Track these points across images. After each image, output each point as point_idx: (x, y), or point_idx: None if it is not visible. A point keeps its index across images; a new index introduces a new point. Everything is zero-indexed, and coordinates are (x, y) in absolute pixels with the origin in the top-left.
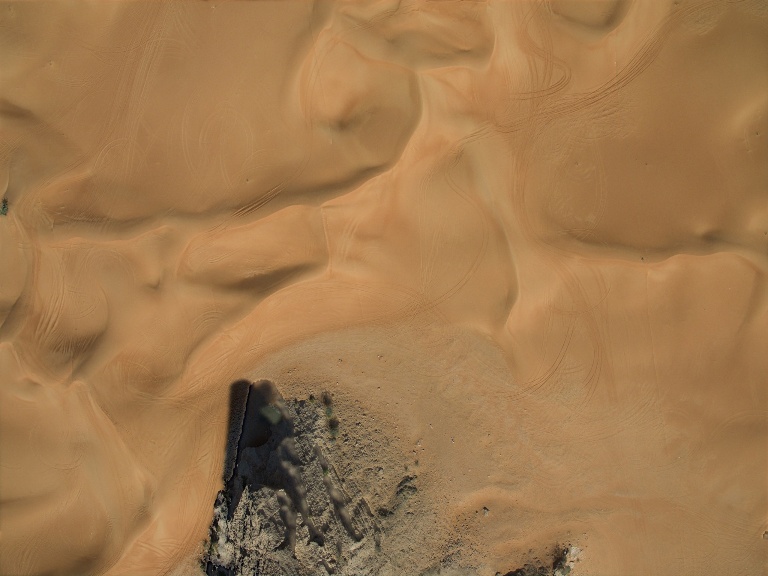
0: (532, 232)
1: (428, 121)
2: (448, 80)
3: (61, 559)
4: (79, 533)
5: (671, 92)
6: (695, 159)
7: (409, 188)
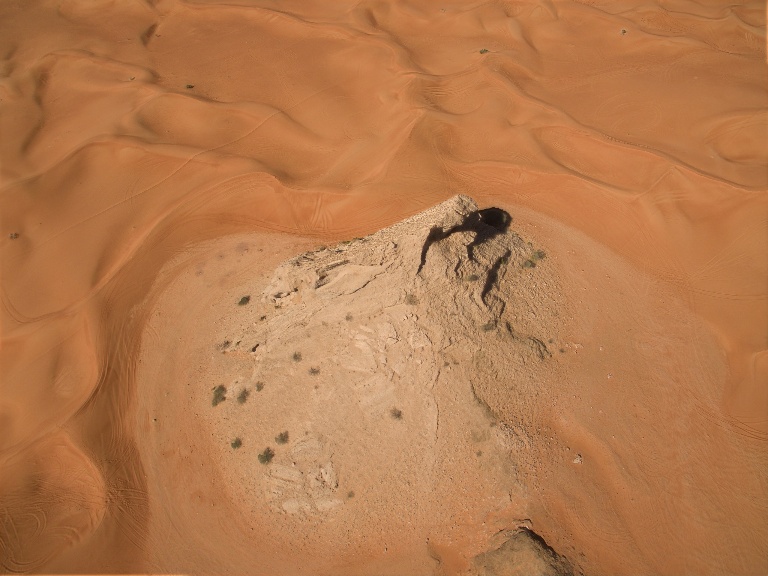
0: None
1: None
2: None
3: (276, 163)
4: (302, 165)
5: None
6: None
7: (751, 214)
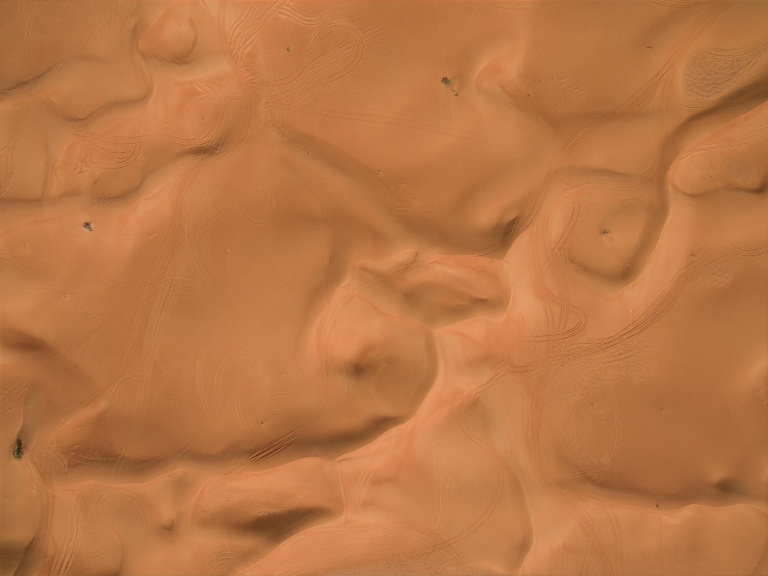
0: (547, 476)
1: (444, 377)
2: (464, 332)
3: None
4: None
5: (687, 341)
6: (711, 407)
7: (424, 435)
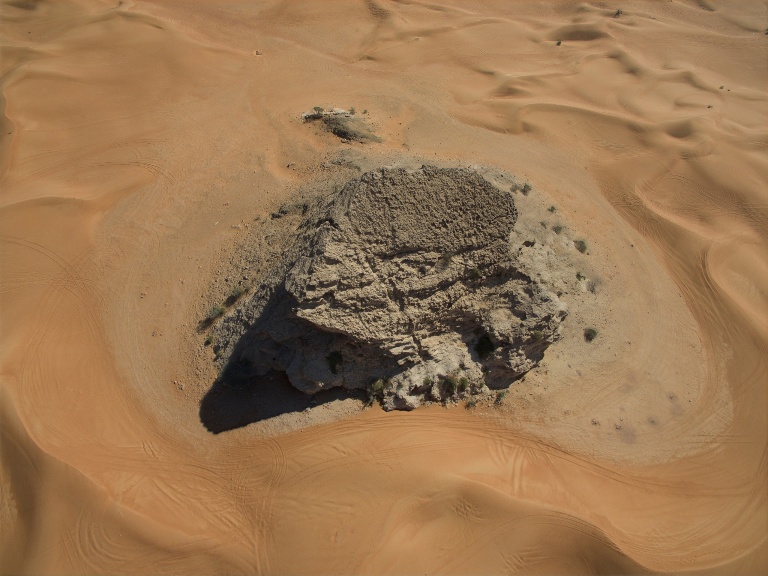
0: None
1: None
2: None
3: None
4: None
5: None
6: None
7: None
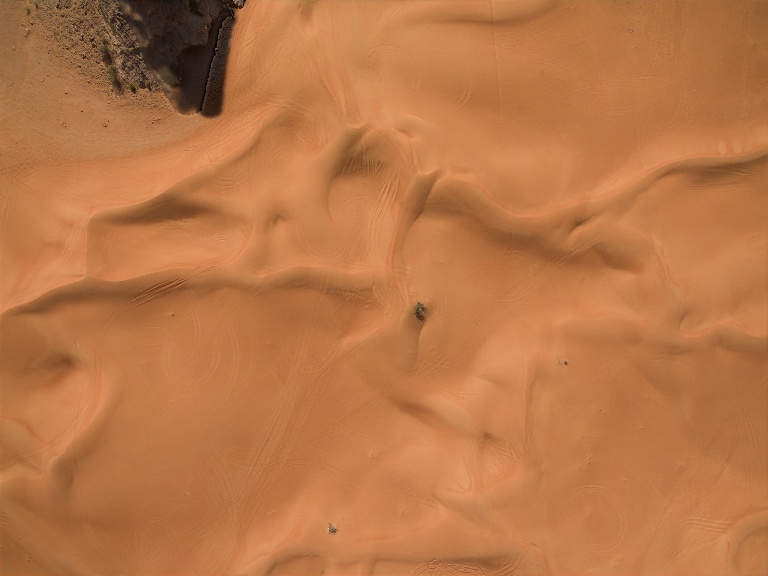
0: None
1: None
2: None
3: None
4: None
5: None
6: None
7: (3, 289)
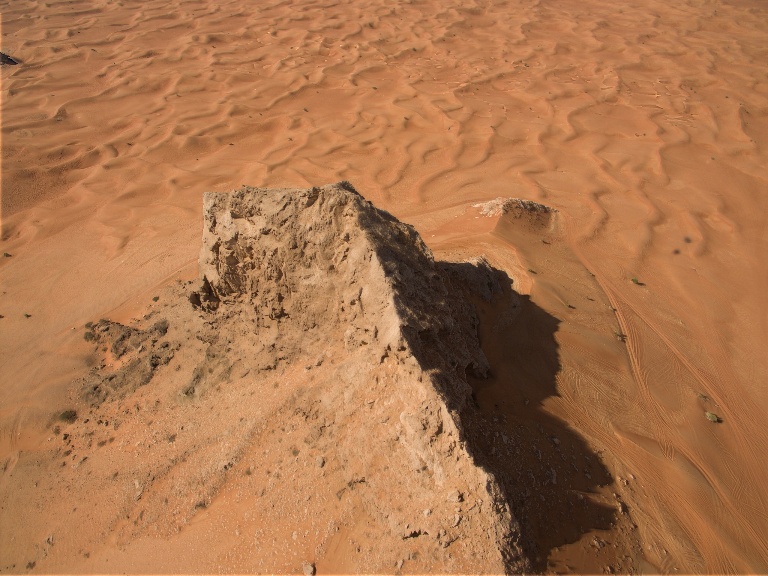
0: None
1: None
2: None
3: None
4: None
5: None
6: None
7: None
